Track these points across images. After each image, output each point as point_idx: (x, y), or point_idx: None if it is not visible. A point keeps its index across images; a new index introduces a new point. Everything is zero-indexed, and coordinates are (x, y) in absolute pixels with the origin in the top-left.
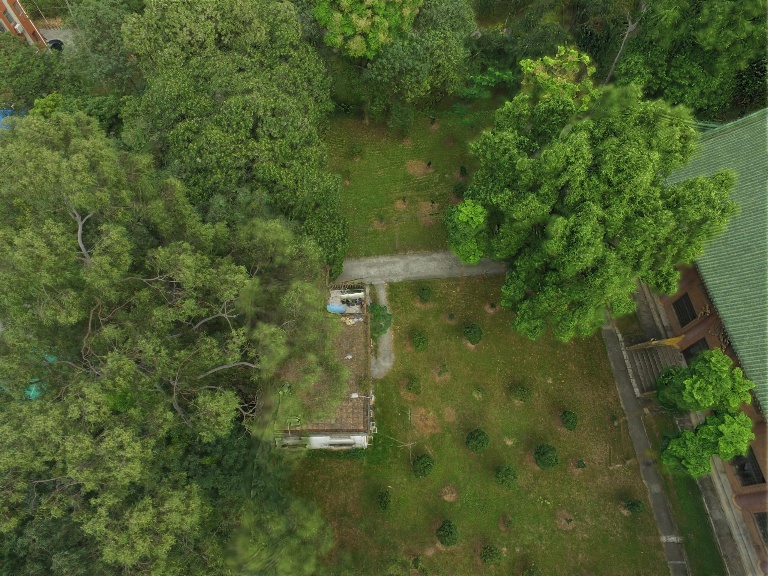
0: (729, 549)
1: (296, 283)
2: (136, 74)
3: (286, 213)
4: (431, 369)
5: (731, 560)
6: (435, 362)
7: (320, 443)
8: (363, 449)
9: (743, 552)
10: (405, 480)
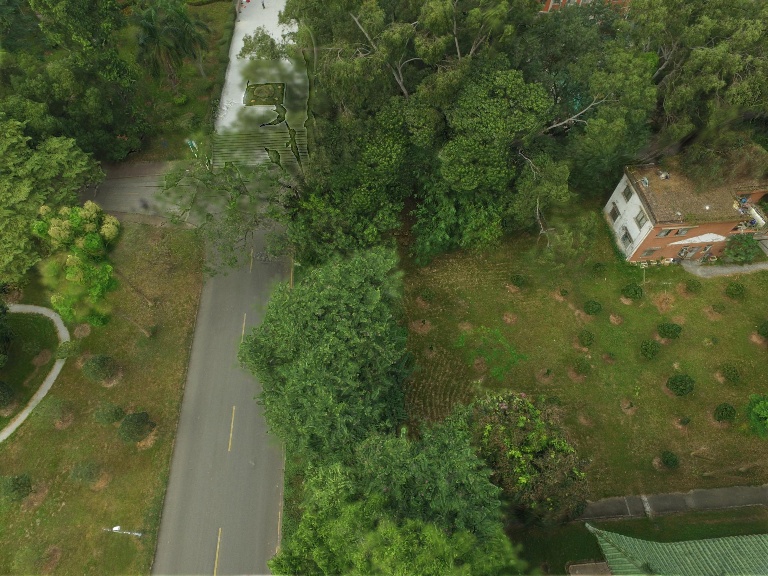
0: None
1: None
2: None
3: None
4: None
5: None
6: None
7: (625, 221)
8: (626, 258)
9: None
10: (614, 289)
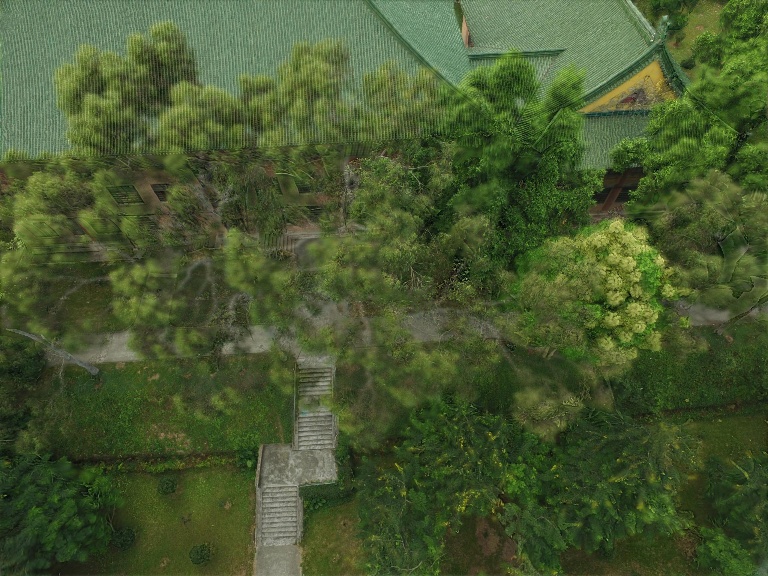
0: None
1: None
2: None
3: None
4: None
5: None
6: (766, 107)
7: None
8: None
9: None
10: None
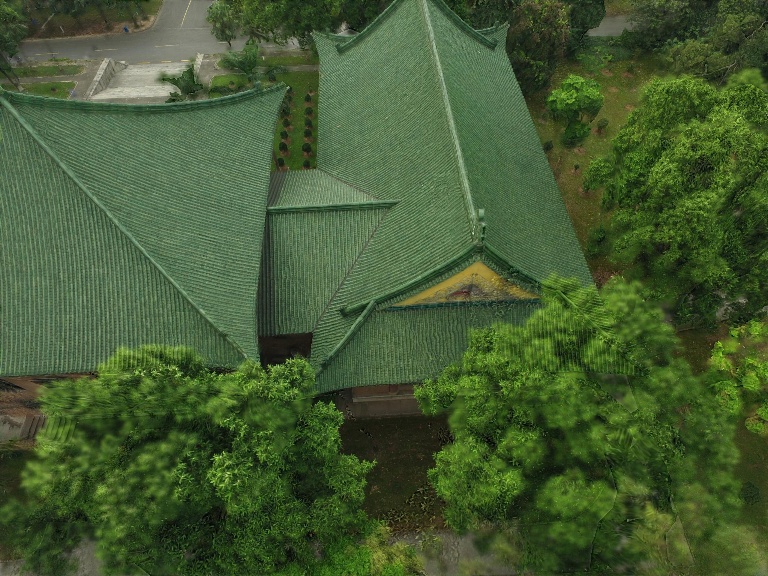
0: None
1: None
2: None
3: None
4: None
5: None
6: None
7: None
8: None
9: None
10: None
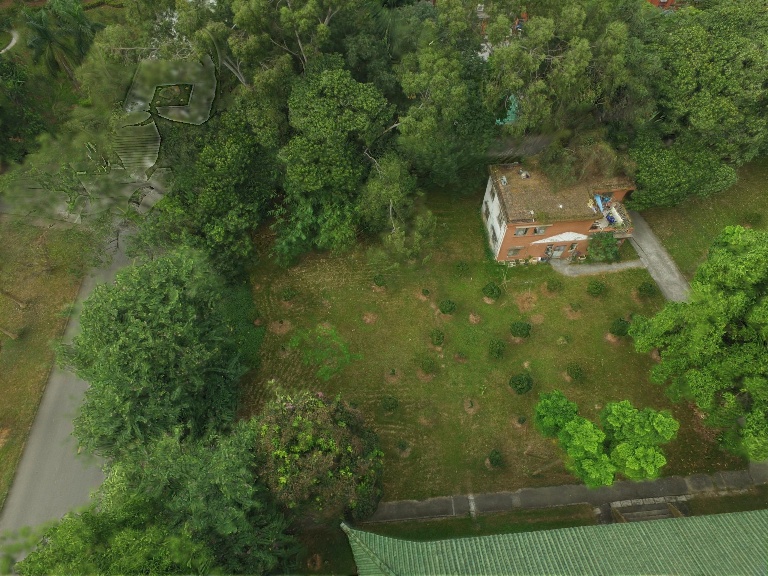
0: None
1: (606, 143)
2: (736, 3)
3: (659, 104)
4: None
5: None
6: None
7: None
8: (495, 257)
9: None
10: (478, 288)
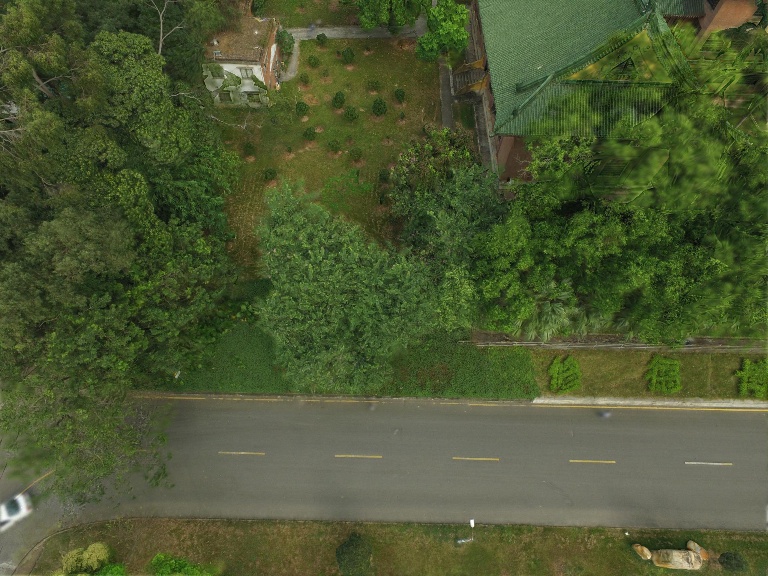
0: (486, 157)
1: None
2: None
3: None
4: (320, 78)
5: (485, 161)
6: None
7: (238, 90)
8: (268, 106)
9: (492, 156)
10: (292, 123)
